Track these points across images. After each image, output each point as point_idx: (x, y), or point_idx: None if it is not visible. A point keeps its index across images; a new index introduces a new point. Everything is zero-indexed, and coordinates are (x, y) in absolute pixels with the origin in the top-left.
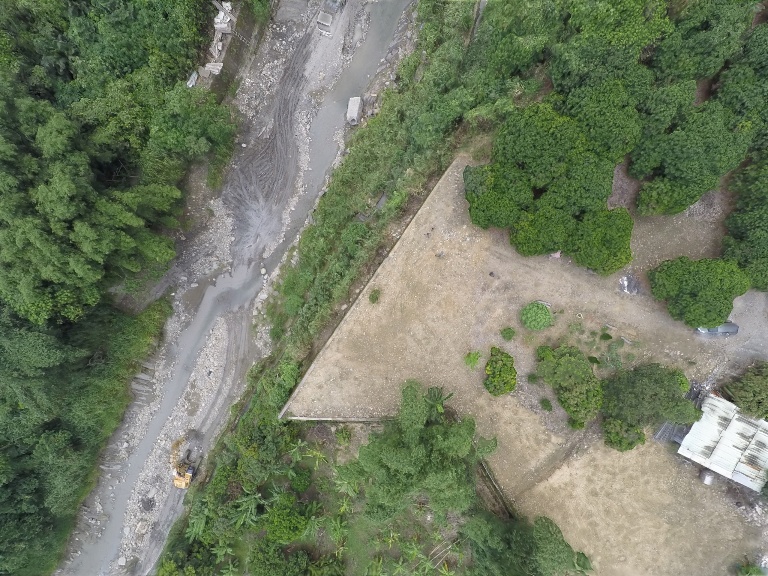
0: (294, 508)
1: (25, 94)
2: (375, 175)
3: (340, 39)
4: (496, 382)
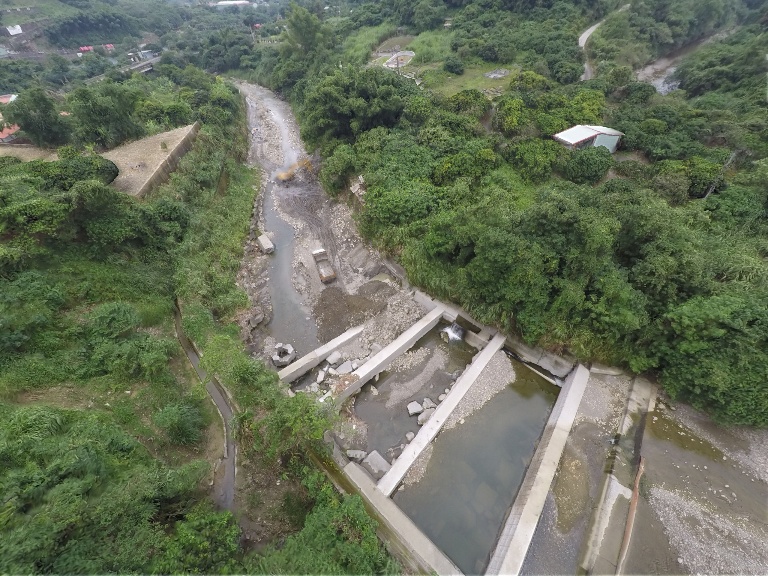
0: (174, 115)
1: (379, 99)
2: (206, 196)
3: (309, 265)
4: (69, 147)
